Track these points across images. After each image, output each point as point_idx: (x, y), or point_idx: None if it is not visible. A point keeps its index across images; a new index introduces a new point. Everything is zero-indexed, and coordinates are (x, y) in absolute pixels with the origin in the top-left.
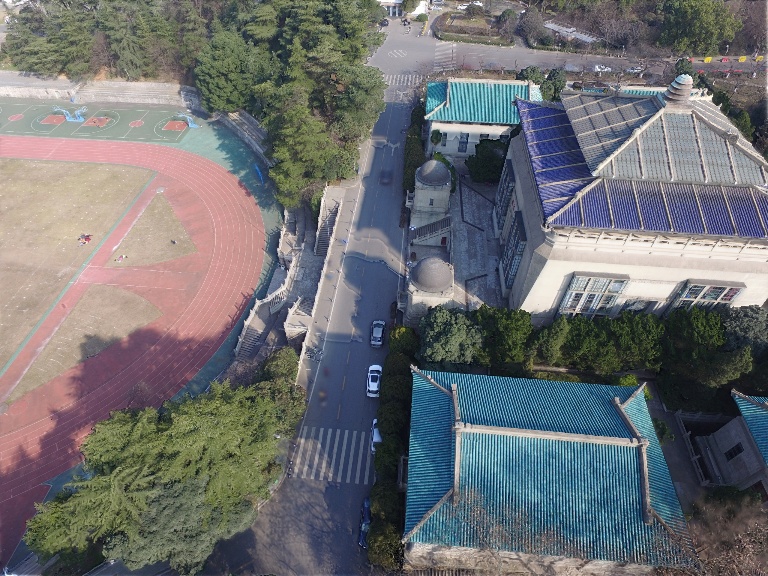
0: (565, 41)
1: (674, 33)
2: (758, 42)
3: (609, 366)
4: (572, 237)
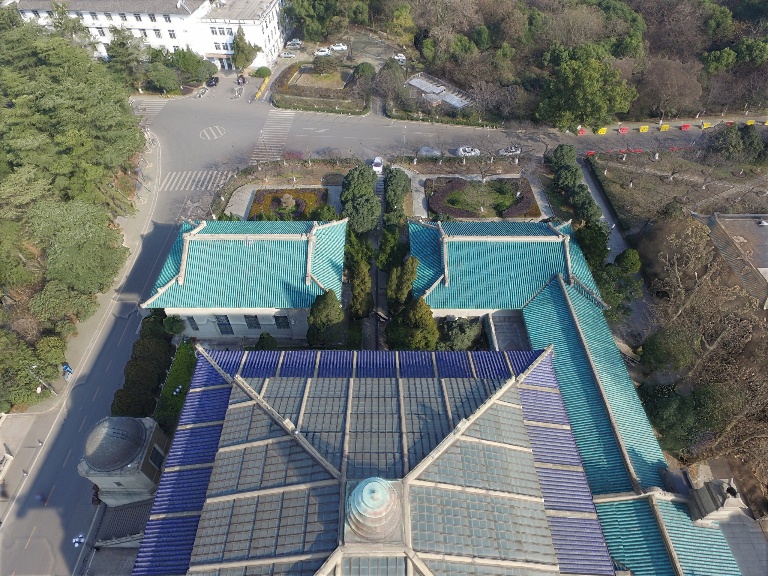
0: None
1: (555, 103)
2: (661, 108)
3: None
4: None
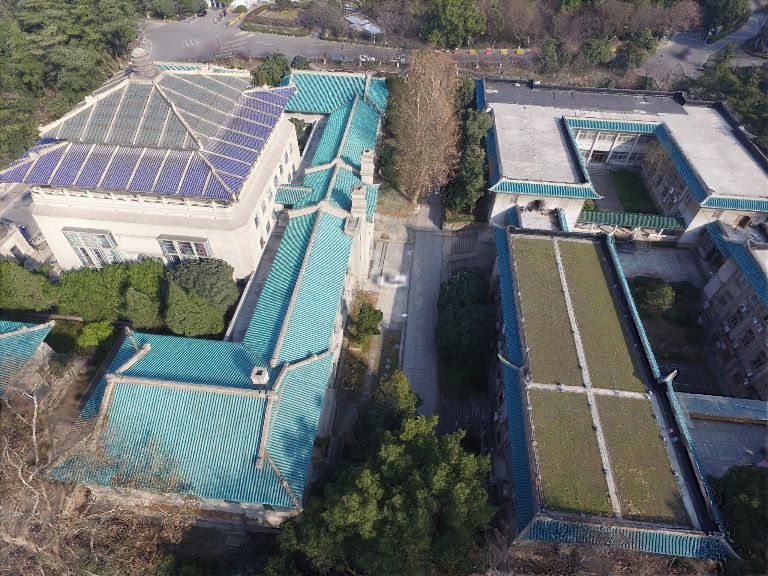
0: (352, 32)
1: (432, 25)
2: (516, 35)
3: (86, 312)
4: (44, 194)
